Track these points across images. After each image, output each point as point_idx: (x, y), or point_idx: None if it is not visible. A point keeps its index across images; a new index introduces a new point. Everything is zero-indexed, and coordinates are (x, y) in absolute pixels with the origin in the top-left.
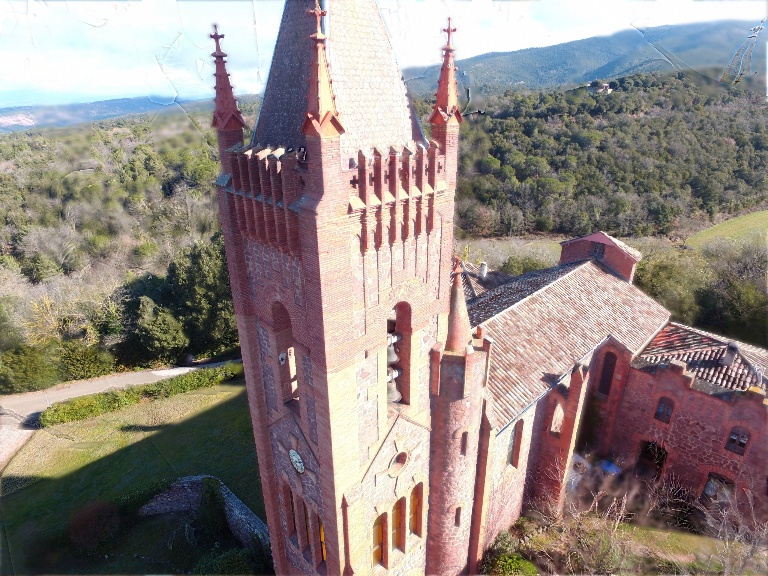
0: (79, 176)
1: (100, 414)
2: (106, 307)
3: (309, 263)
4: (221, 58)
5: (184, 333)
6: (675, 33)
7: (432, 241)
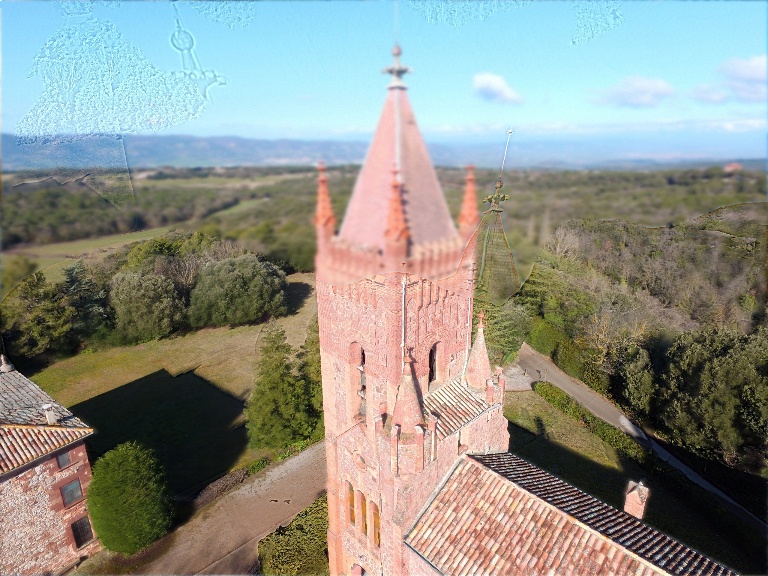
0: (705, 235)
1: (557, 408)
2: (621, 343)
3: None
4: None
5: (651, 400)
6: (650, 179)
7: (380, 317)
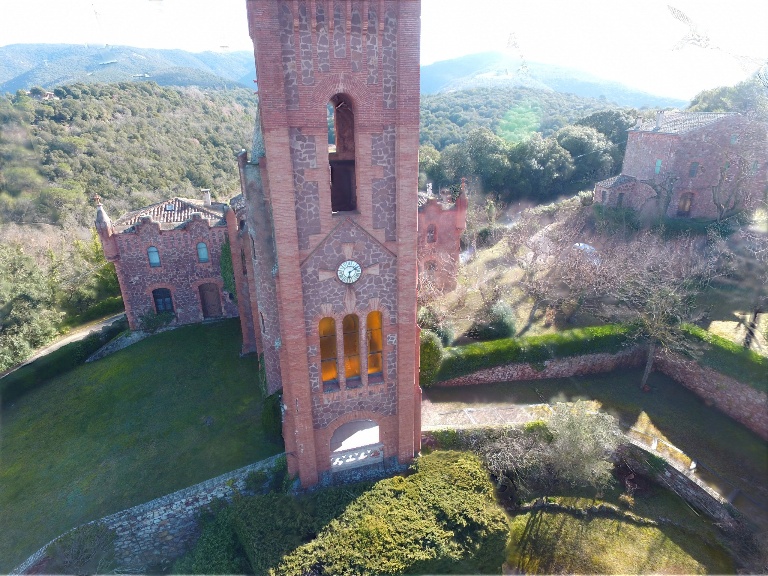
0: None
1: None
2: None
3: (408, 28)
4: None
5: None
6: None
7: None
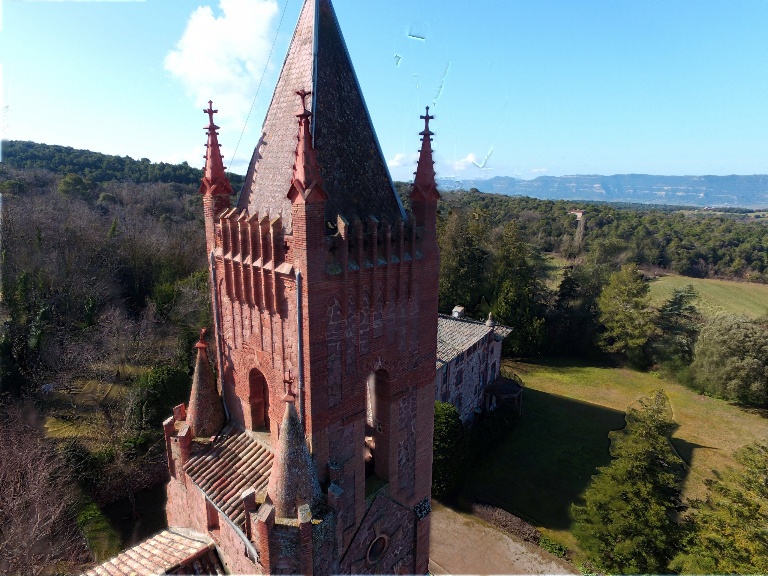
0: None
1: None
2: None
3: None
4: (425, 136)
5: None
6: None
7: None
